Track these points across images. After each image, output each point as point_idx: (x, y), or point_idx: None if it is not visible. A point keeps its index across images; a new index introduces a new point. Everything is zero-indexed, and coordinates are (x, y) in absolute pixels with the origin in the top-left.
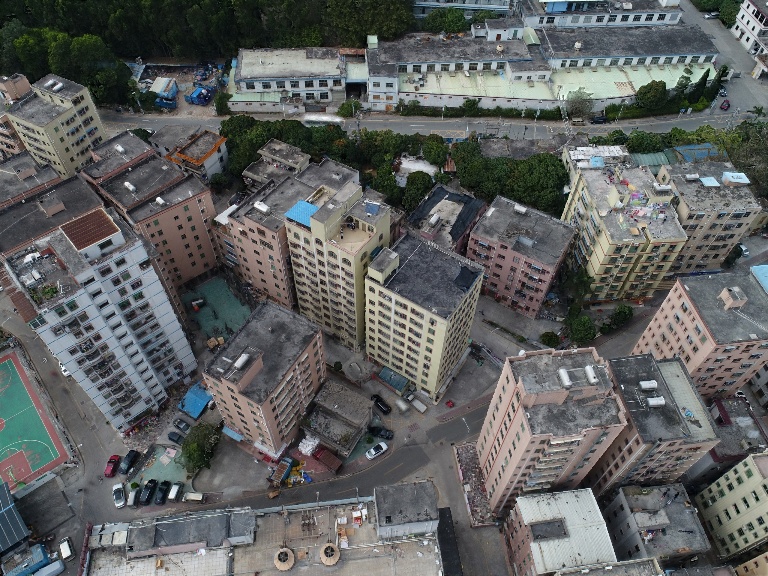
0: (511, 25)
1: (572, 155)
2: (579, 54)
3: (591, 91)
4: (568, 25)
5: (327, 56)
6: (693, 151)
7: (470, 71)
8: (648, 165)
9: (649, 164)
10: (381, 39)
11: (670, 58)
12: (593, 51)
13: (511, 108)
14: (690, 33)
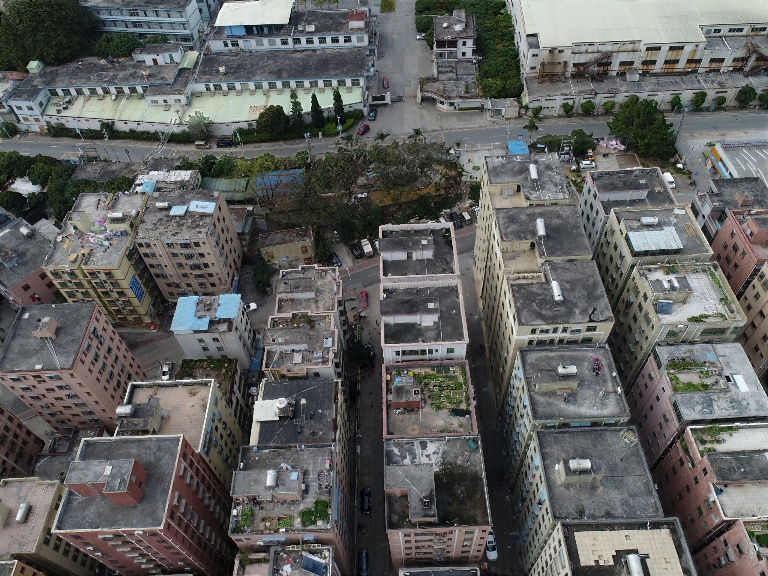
0: (165, 50)
1: (139, 179)
2: (222, 78)
3: (221, 115)
4: (255, 48)
5: (4, 80)
6: (271, 177)
7: (119, 95)
8: (224, 190)
9: (225, 189)
10: (49, 64)
11: (315, 82)
12: (238, 75)
13: (143, 131)
14: (351, 56)
